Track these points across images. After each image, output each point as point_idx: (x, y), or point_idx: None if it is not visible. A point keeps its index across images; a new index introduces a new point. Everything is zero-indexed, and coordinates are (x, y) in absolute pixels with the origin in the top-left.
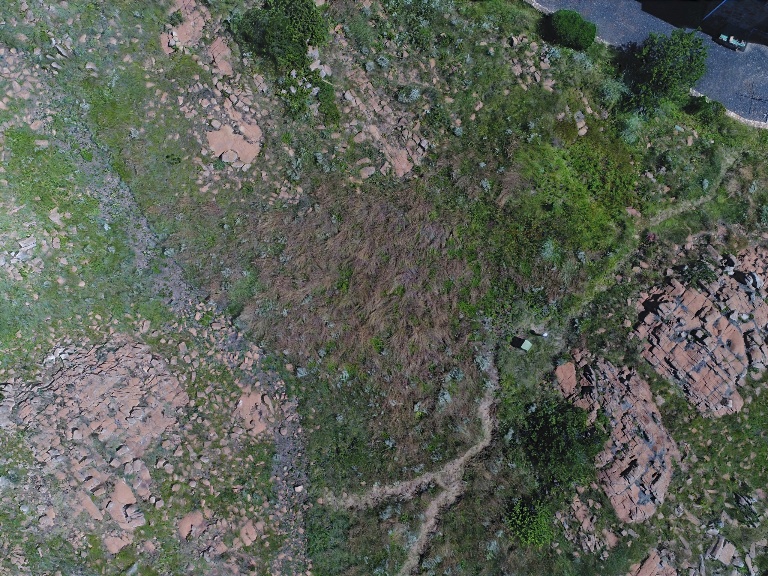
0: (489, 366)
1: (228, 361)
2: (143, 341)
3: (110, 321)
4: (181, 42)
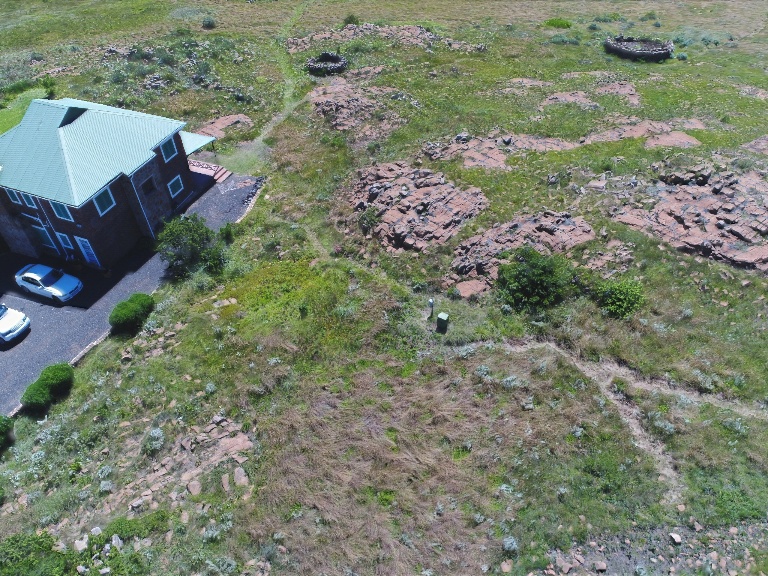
0: None
1: None
2: None
3: None
4: None
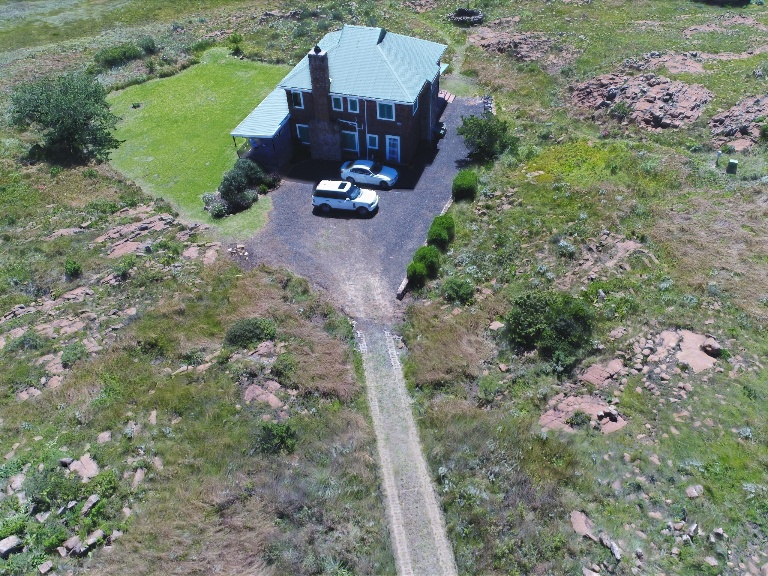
0: None
1: None
2: None
3: None
4: None
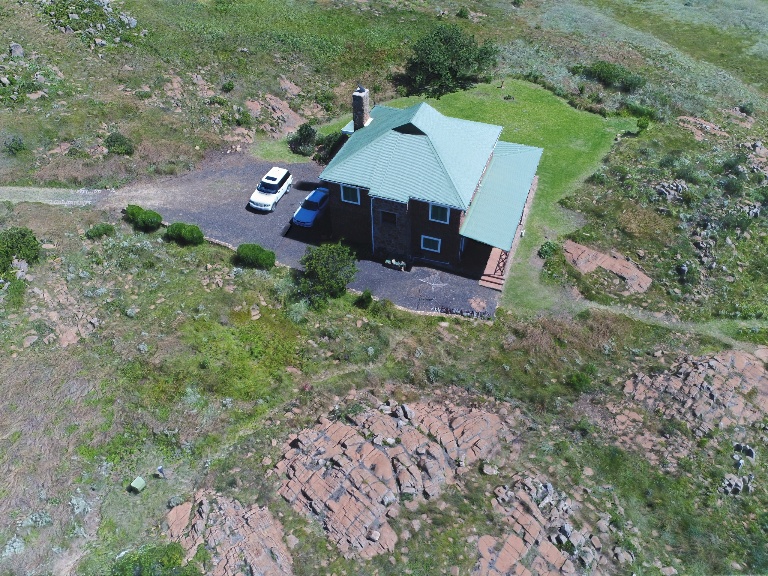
0: (91, 513)
1: None
2: None
3: None
4: None
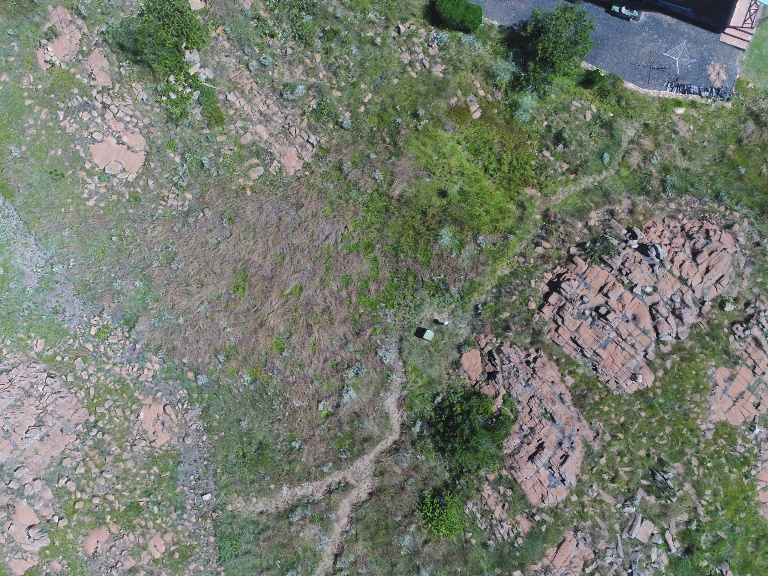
0: (394, 359)
1: (127, 374)
2: (38, 360)
3: (3, 342)
4: (57, 57)
